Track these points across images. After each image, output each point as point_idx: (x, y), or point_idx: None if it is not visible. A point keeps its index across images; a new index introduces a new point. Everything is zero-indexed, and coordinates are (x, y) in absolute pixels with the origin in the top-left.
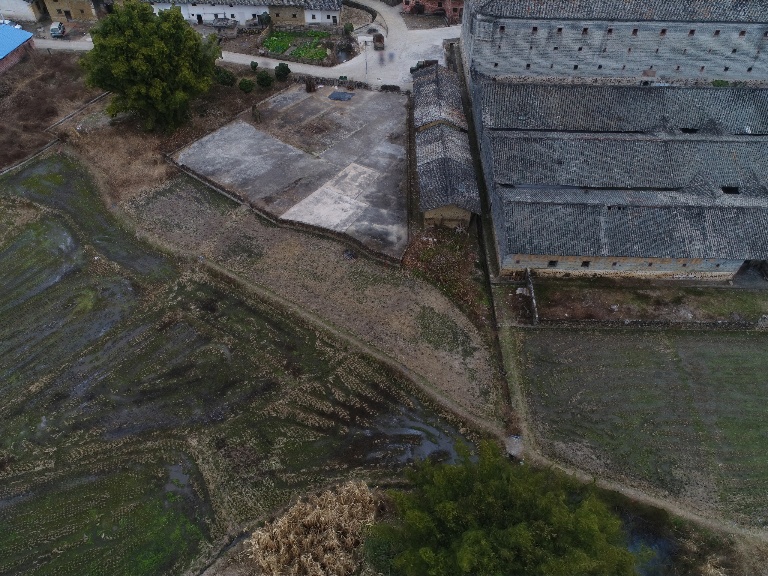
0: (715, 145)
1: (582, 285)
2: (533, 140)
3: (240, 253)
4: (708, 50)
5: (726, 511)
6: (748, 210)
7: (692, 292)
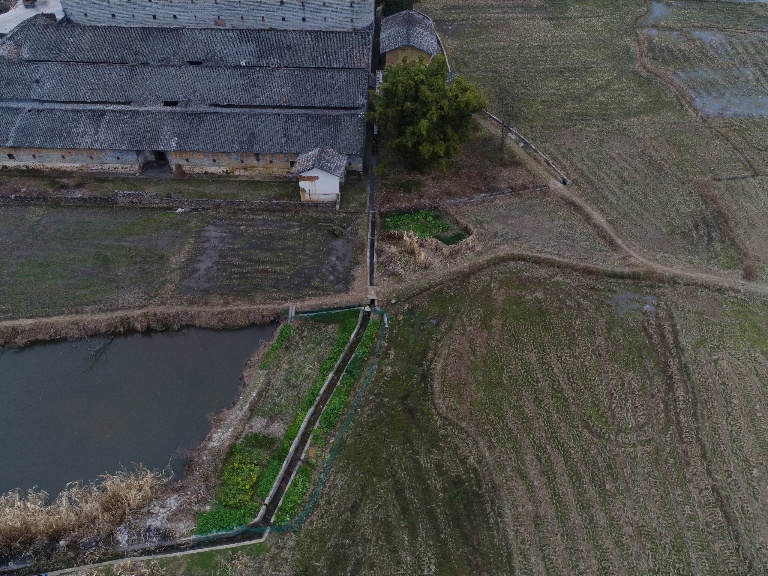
0: (173, 69)
1: (14, 175)
2: (23, 64)
3: None
4: (259, 2)
5: None
6: (142, 113)
7: (99, 180)
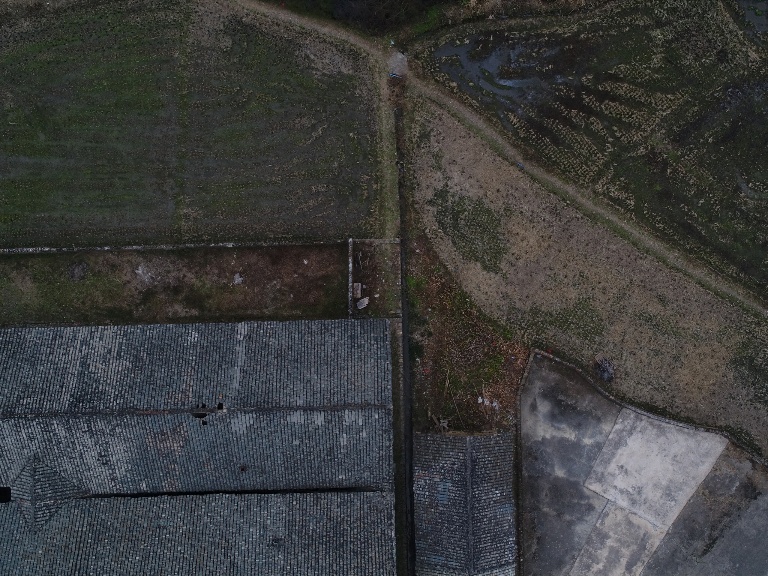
0: None
1: None
2: None
3: (767, 365)
4: None
5: (190, 1)
6: None
7: (123, 314)
